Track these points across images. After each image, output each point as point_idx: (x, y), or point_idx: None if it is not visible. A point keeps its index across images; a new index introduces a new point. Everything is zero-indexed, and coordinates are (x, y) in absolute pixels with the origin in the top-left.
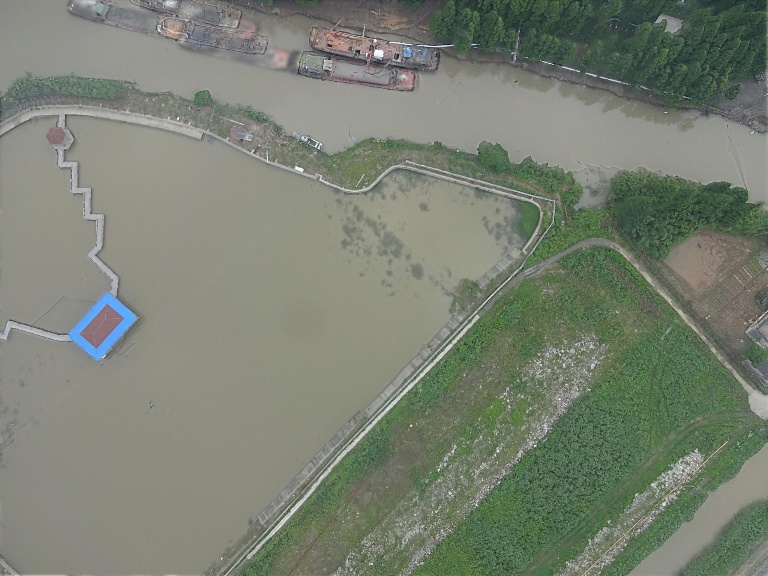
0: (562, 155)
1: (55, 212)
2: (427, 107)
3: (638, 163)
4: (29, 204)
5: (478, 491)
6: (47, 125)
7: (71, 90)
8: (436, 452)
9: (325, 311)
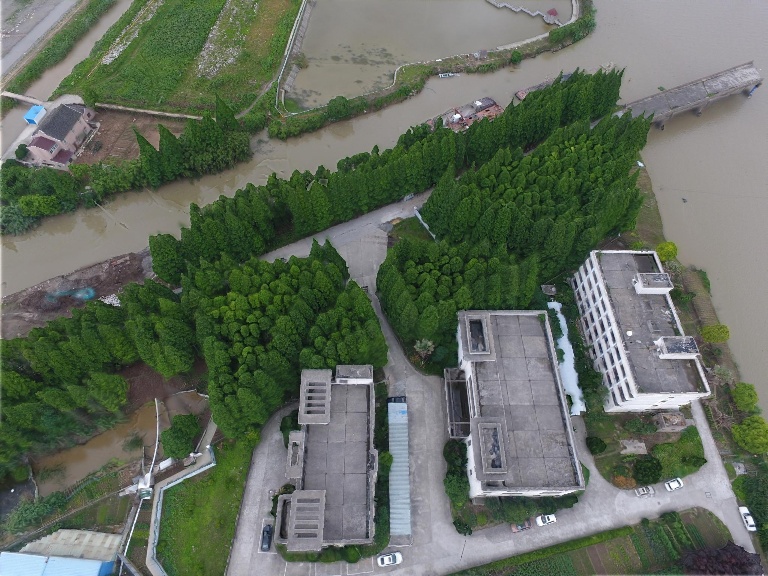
0: (299, 168)
1: (519, 3)
2: (404, 122)
3: None
4: (532, 0)
5: (230, 4)
6: (563, 21)
7: (569, 24)
8: (263, 8)
9: (367, 28)
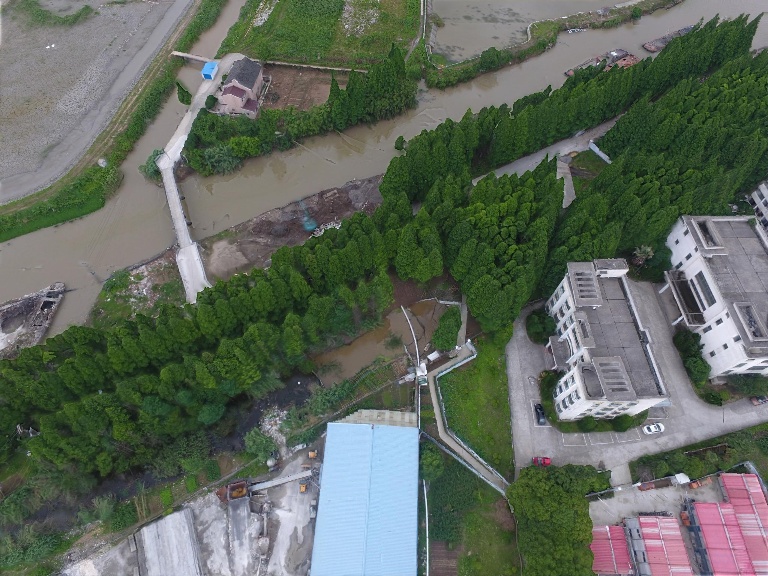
0: (455, 116)
1: None
2: None
3: (405, 152)
4: None
5: None
6: None
7: None
8: None
9: None
